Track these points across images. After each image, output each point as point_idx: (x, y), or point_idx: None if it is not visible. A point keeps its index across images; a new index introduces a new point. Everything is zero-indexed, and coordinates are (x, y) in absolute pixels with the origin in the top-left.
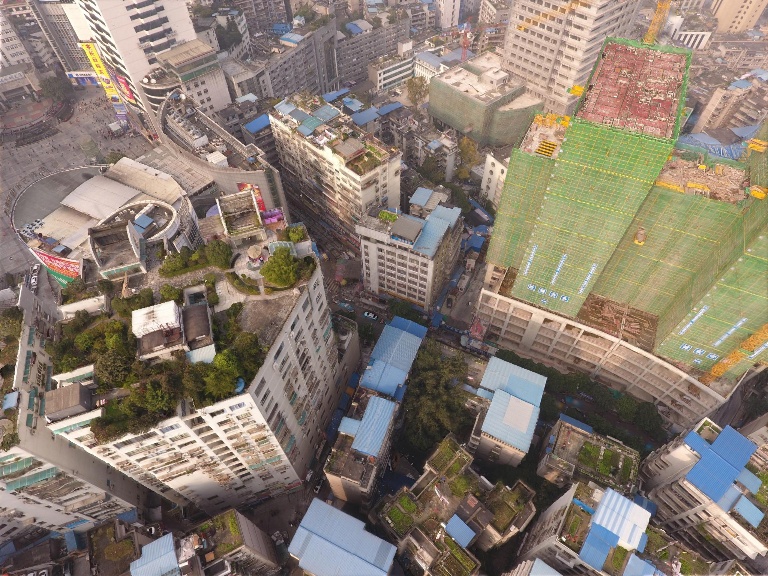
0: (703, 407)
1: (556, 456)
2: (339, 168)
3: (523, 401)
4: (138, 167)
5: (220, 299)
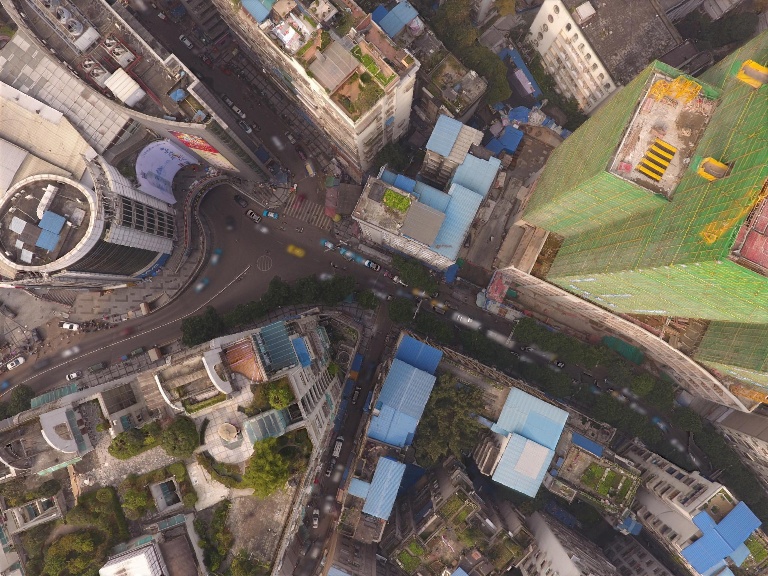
0: (721, 400)
1: (560, 483)
2: (320, 94)
3: (539, 445)
4: (3, 92)
5: (198, 492)
